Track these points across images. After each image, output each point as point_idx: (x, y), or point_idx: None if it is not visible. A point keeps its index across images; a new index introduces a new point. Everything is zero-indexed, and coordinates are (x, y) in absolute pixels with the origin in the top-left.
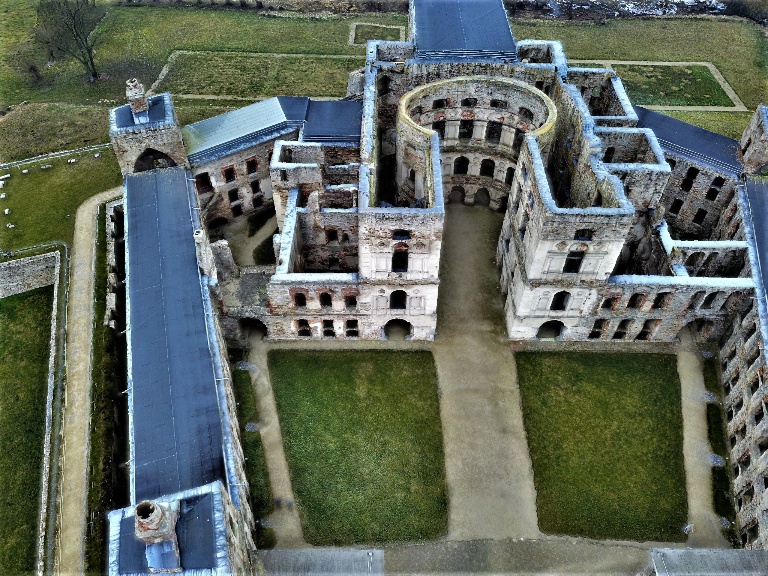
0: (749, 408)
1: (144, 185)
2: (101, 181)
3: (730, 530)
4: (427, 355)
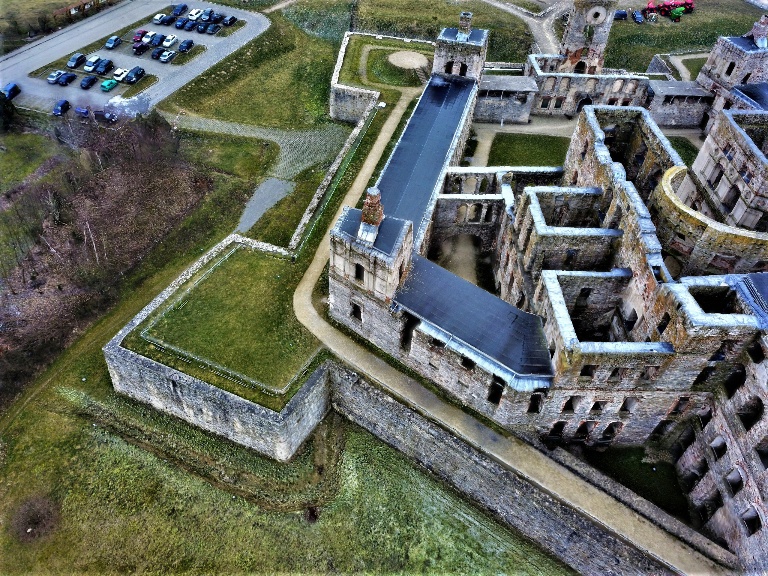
0: None
1: None
2: None
3: (473, 136)
4: None
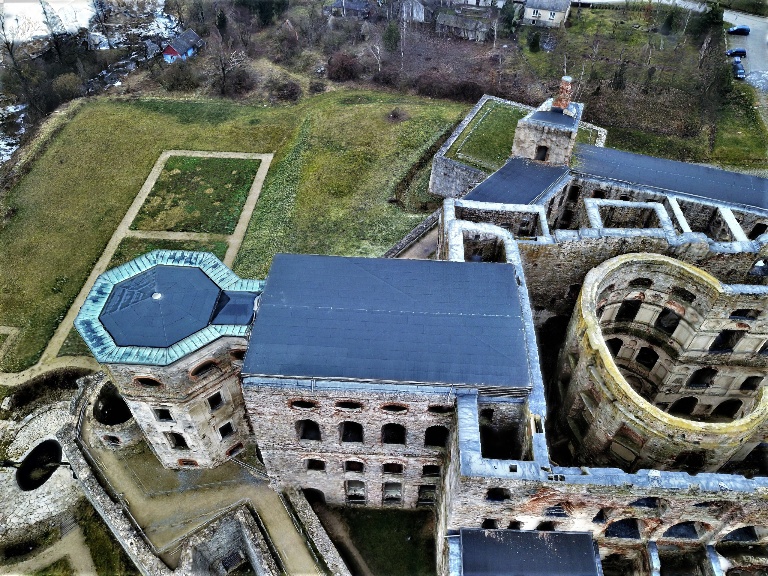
0: None
1: None
2: None
3: None
4: None
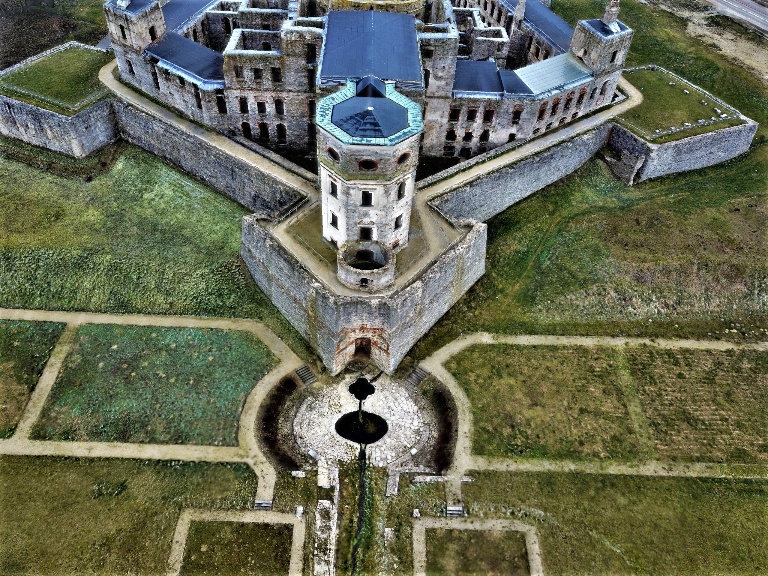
0: None
1: None
2: (647, 110)
3: None
4: None
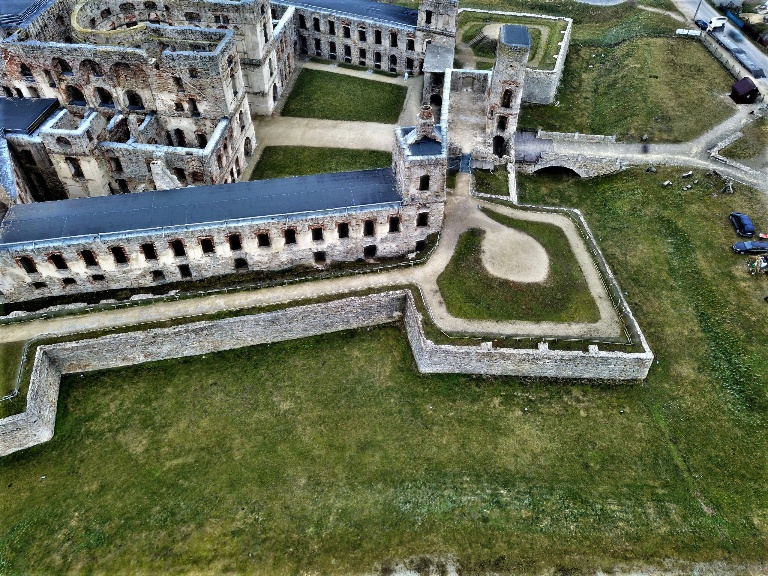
0: (355, 41)
1: (26, 228)
2: None
3: None
4: (268, 148)
